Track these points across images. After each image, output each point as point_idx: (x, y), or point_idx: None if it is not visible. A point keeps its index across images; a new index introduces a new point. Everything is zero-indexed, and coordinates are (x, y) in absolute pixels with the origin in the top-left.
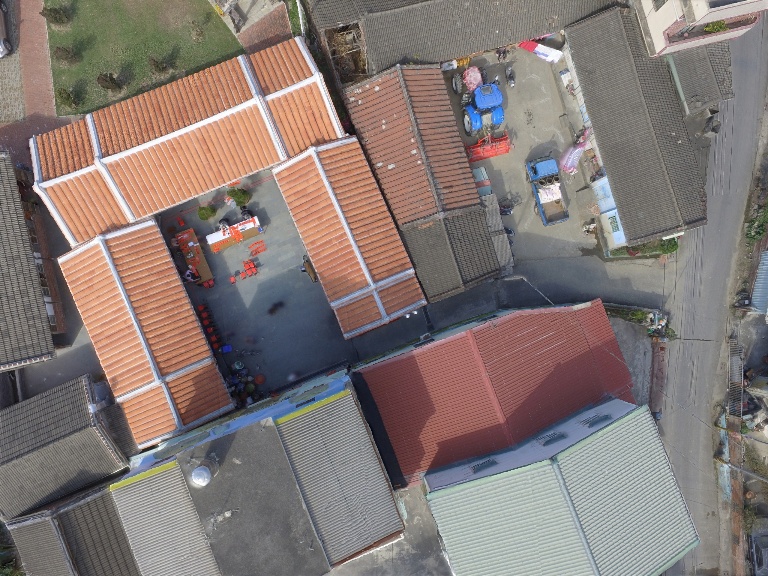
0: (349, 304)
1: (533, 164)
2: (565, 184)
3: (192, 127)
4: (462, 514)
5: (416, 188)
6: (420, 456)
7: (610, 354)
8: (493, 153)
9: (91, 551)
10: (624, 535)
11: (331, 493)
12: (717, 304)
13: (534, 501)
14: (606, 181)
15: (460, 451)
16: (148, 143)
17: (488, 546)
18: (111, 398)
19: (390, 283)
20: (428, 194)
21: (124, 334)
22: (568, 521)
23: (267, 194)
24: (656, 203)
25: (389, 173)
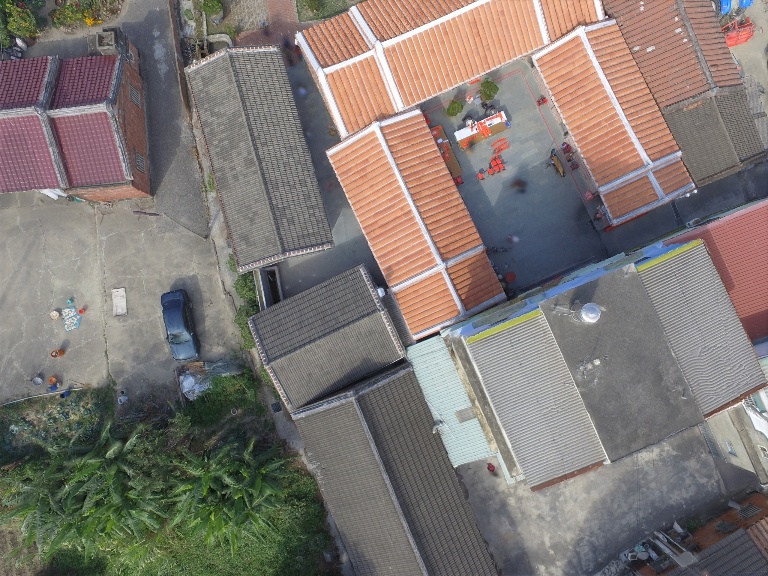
0: (619, 188)
1: None
2: None
3: (466, 8)
4: None
5: (681, 68)
6: None
7: None
8: (733, 42)
9: (386, 436)
10: None
11: (694, 343)
12: None
13: None
14: None
15: (764, 327)
16: (424, 26)
17: None
18: None
19: (662, 164)
20: (697, 72)
21: (400, 222)
22: None
23: (507, 91)
24: None
25: (648, 56)
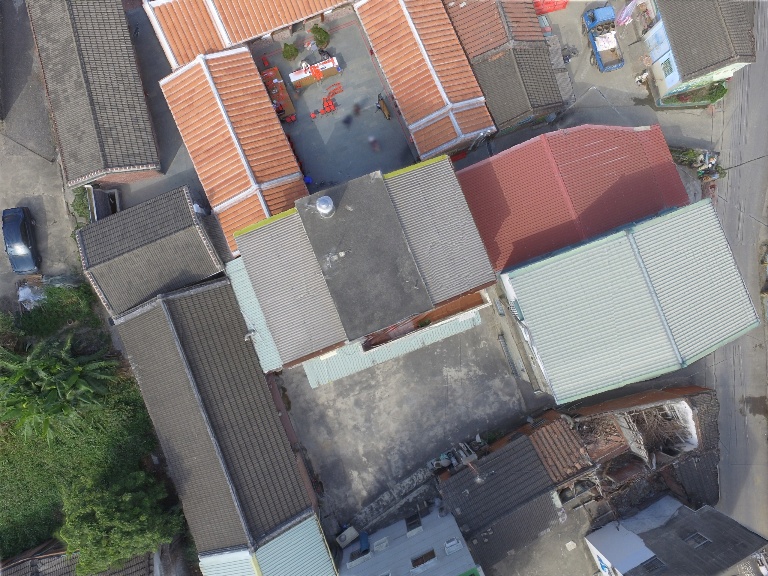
0: (426, 127)
1: (591, 13)
2: (618, 38)
3: None
4: (542, 289)
5: (487, 22)
6: (496, 256)
7: (668, 173)
8: (551, 7)
9: (195, 338)
10: (692, 306)
11: None
12: (762, 151)
13: (610, 271)
14: (660, 26)
15: (534, 249)
16: None
17: (566, 317)
18: (208, 210)
19: (464, 107)
20: (498, 26)
21: (222, 147)
22: (642, 287)
23: (343, 40)
24: (709, 38)
25: (461, 11)
